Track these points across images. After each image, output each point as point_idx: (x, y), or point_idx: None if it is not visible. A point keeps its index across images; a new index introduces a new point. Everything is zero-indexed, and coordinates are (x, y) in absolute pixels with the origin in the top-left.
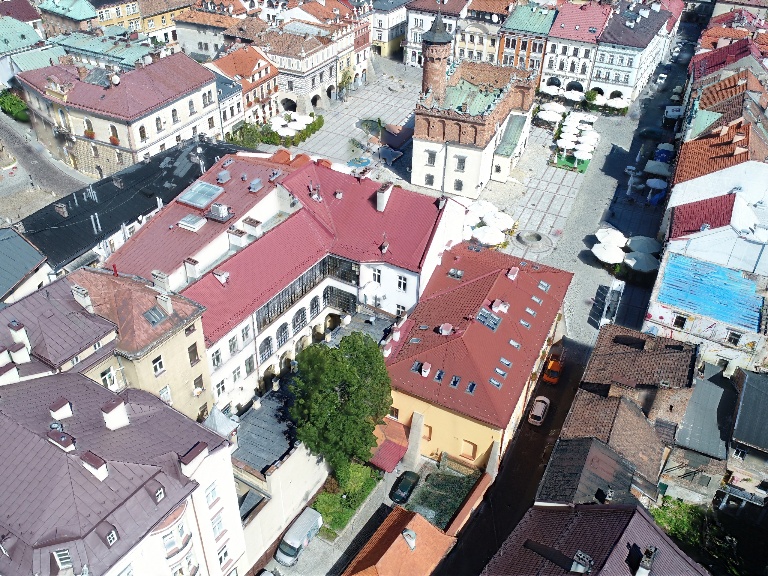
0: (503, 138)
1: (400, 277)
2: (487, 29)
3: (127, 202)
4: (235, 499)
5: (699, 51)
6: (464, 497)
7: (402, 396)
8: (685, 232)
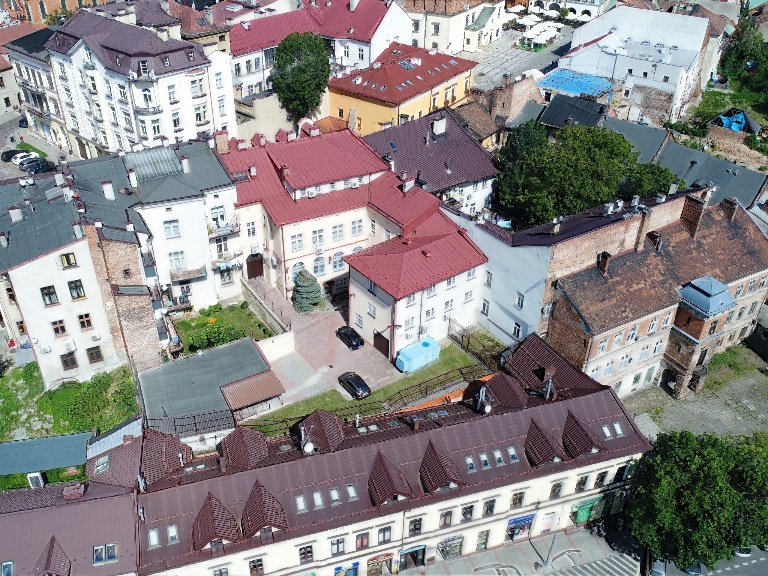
0: (476, 21)
1: (360, 50)
2: None
3: (199, 7)
4: (233, 97)
5: None
6: None
7: (345, 98)
8: None
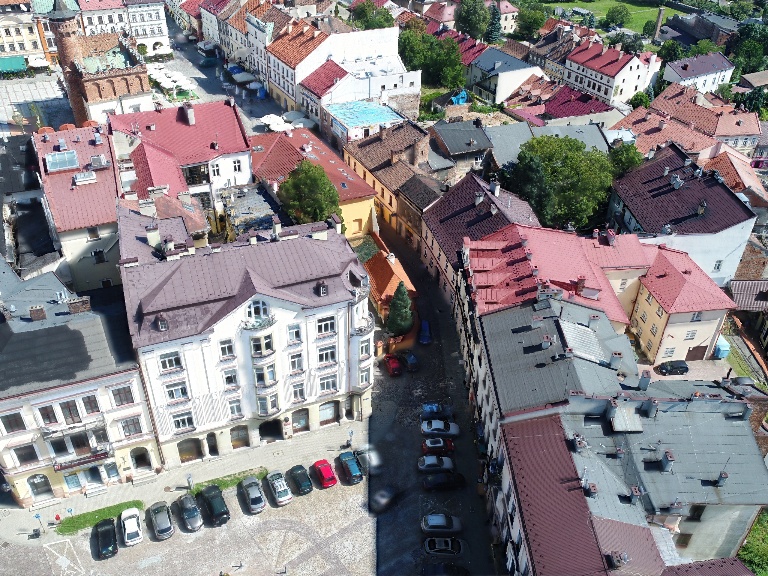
0: None
1: (235, 162)
2: (20, 19)
3: None
4: None
5: (182, 1)
6: (377, 246)
7: None
8: (325, 89)
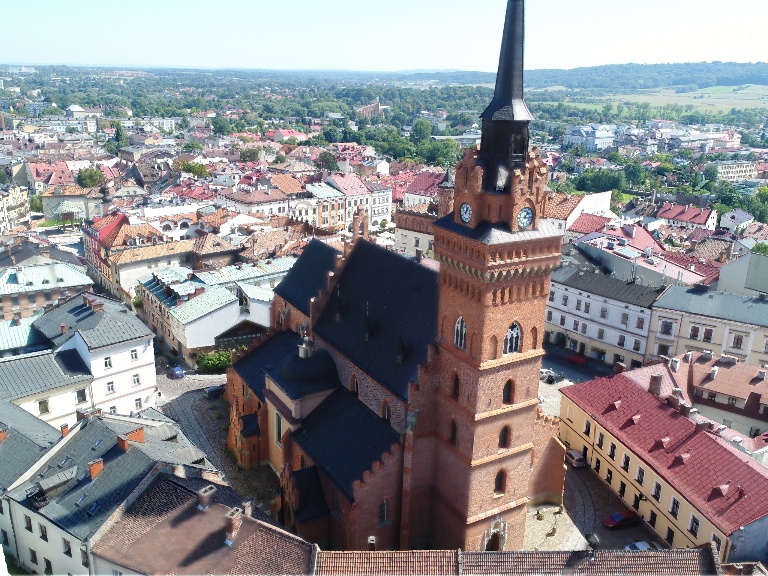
0: None
1: None
2: (310, 203)
3: None
4: None
5: None
6: None
7: None
8: (599, 230)
